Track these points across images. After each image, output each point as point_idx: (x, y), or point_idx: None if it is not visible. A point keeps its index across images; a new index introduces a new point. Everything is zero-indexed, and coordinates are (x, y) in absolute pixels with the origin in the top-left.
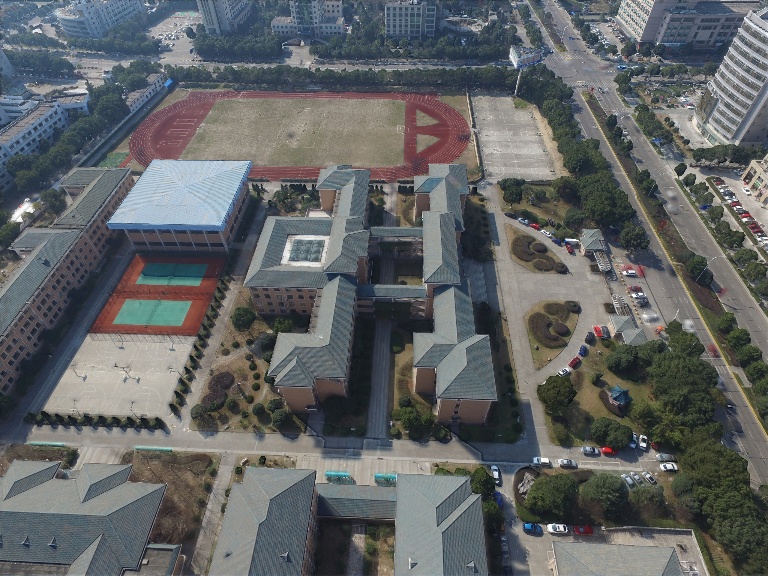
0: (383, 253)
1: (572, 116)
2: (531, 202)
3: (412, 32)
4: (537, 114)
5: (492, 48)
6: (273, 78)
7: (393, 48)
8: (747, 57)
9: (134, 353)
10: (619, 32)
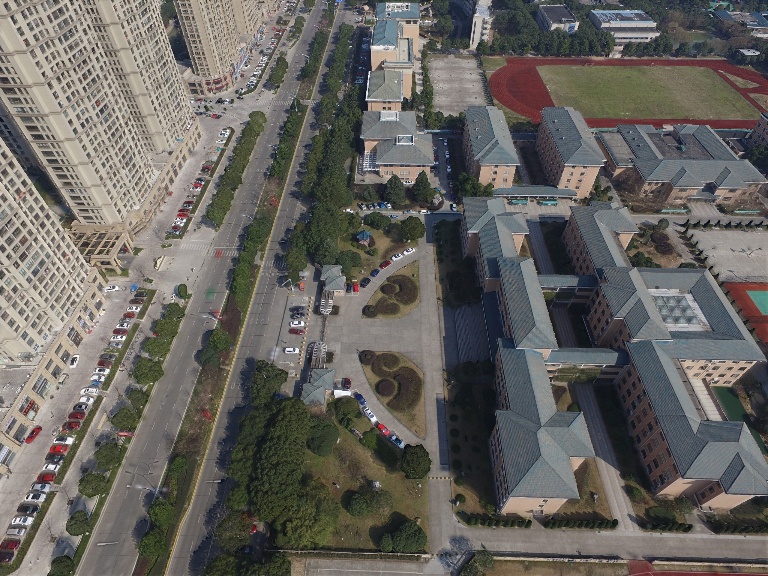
0: None
1: None
2: None
3: None
4: None
5: None
6: None
7: None
8: None
9: (761, 268)
10: None
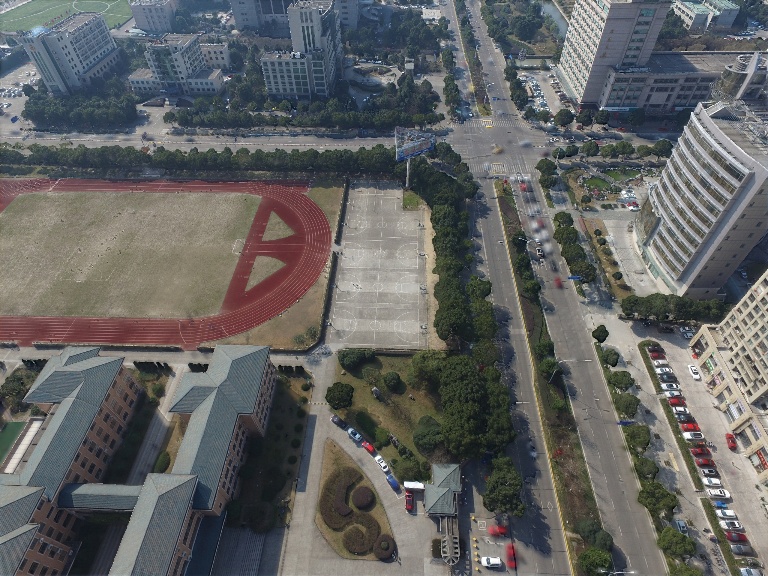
0: (107, 520)
1: (467, 230)
2: (375, 395)
3: (299, 90)
4: (428, 219)
5: (390, 116)
6: (96, 163)
7: (276, 110)
8: (694, 174)
9: None
10: (560, 85)
